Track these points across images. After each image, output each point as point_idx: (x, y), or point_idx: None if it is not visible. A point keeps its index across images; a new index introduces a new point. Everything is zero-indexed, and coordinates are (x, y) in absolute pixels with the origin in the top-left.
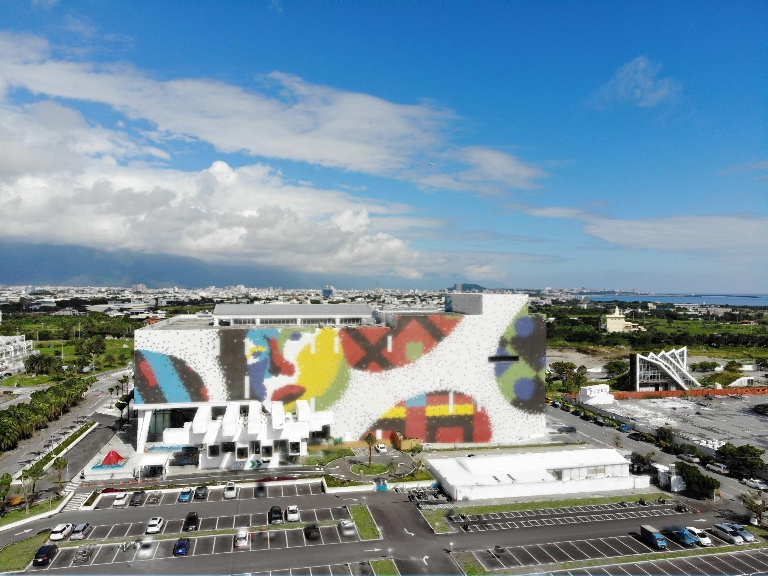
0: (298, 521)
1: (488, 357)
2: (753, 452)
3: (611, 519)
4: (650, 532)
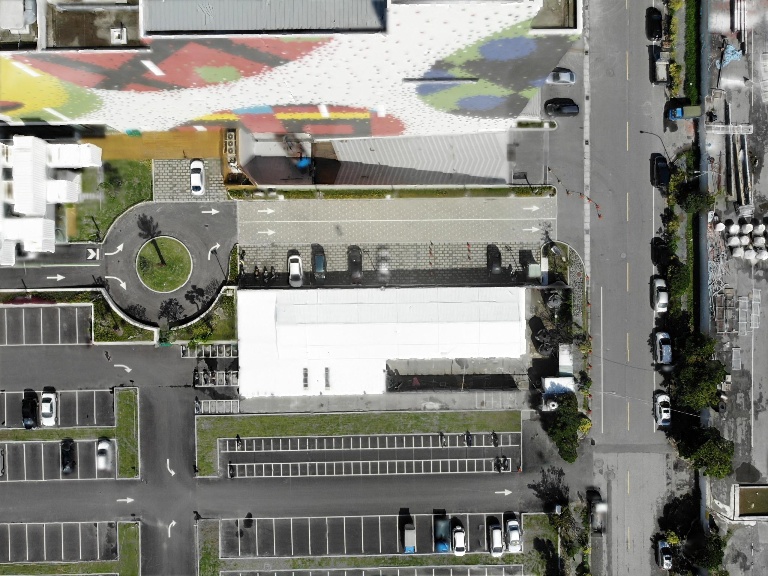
0: (55, 425)
1: (402, 77)
2: (697, 402)
3: (404, 474)
4: (404, 545)
